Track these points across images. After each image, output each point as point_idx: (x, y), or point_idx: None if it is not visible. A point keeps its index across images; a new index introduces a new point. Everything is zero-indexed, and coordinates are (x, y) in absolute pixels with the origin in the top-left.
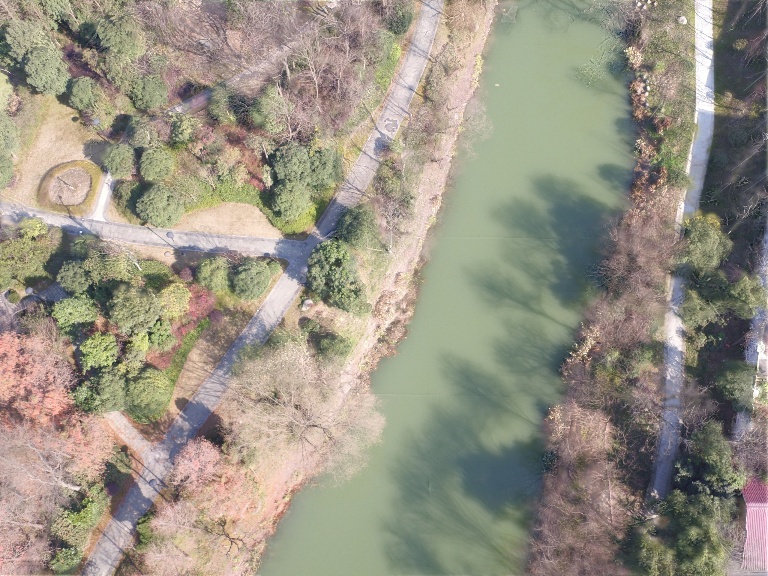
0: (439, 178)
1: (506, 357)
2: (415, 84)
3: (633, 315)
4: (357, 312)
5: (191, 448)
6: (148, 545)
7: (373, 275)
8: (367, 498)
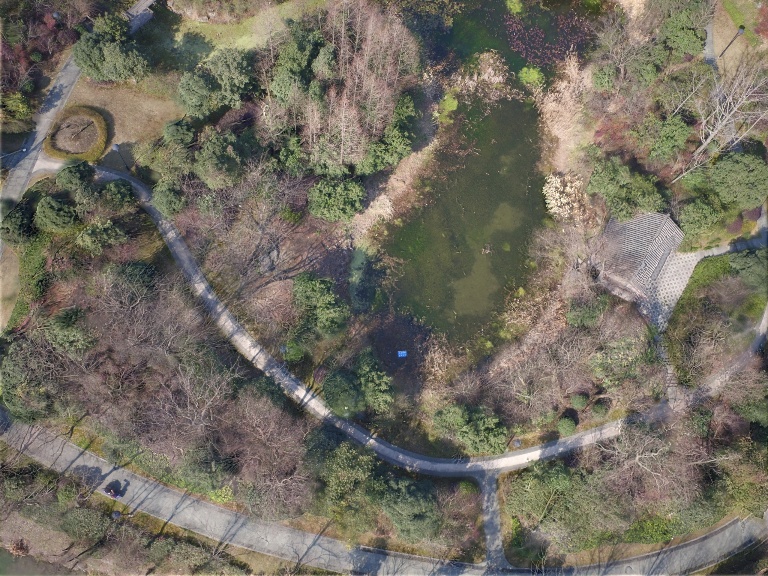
0: (54, 553)
1: None
2: (180, 522)
3: None
4: None
5: None
6: None
7: None
8: None
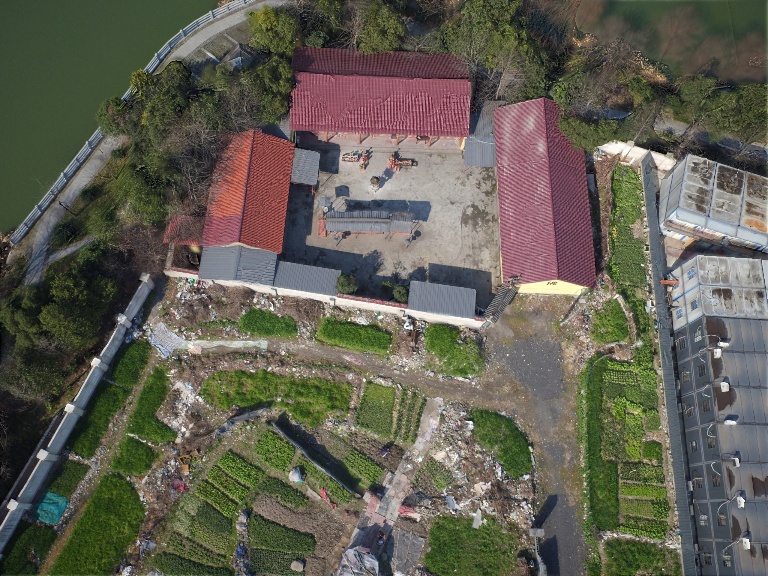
0: None
1: (629, 17)
2: None
3: (682, 82)
4: None
5: None
6: None
7: None
8: None
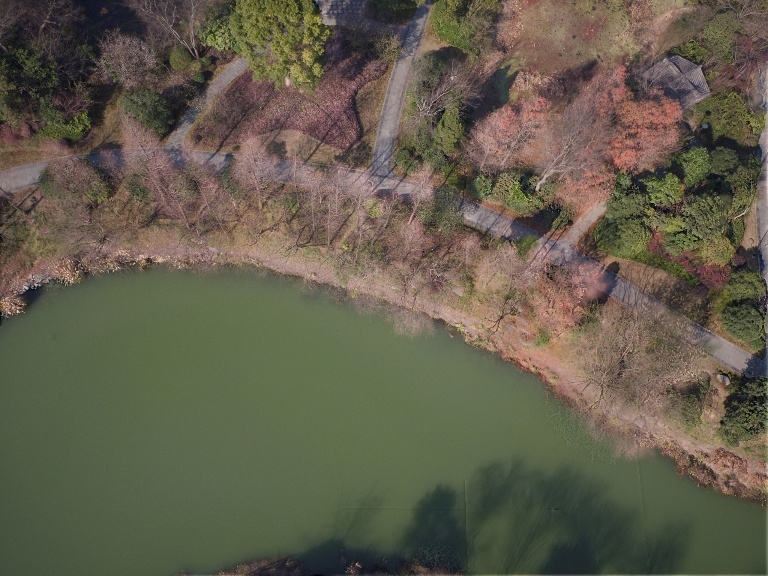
0: None
1: None
2: None
3: None
4: (722, 432)
5: (575, 279)
6: (496, 251)
7: (763, 449)
8: (539, 446)
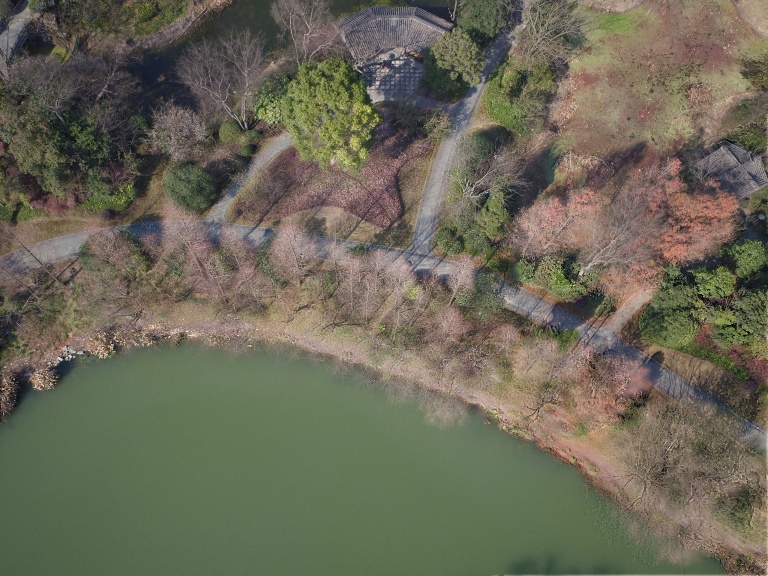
0: None
1: None
2: None
3: None
4: None
5: (619, 369)
6: (537, 337)
7: None
8: (579, 544)
